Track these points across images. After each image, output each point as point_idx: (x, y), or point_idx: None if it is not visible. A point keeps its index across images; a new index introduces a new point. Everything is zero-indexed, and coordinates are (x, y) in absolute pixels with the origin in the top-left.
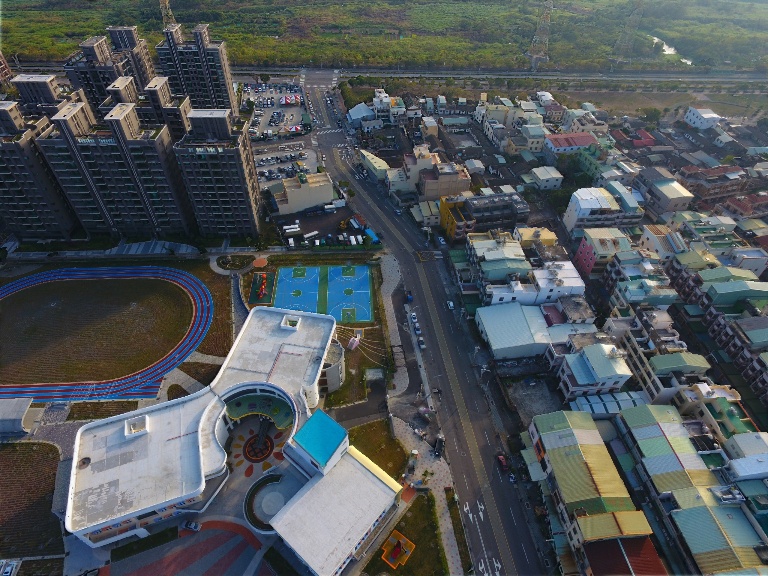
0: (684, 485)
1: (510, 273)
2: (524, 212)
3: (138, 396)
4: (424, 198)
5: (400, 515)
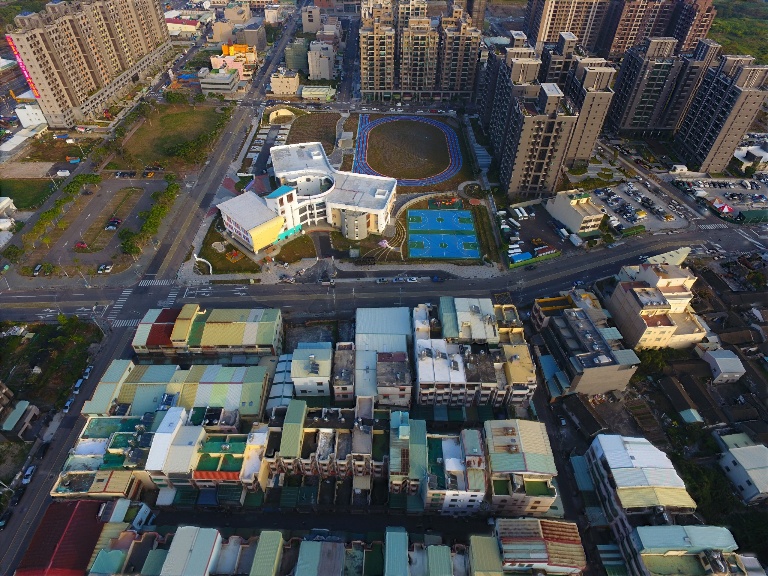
0: (189, 378)
1: (441, 321)
2: (574, 365)
3: (354, 170)
4: (610, 301)
5: (252, 258)
